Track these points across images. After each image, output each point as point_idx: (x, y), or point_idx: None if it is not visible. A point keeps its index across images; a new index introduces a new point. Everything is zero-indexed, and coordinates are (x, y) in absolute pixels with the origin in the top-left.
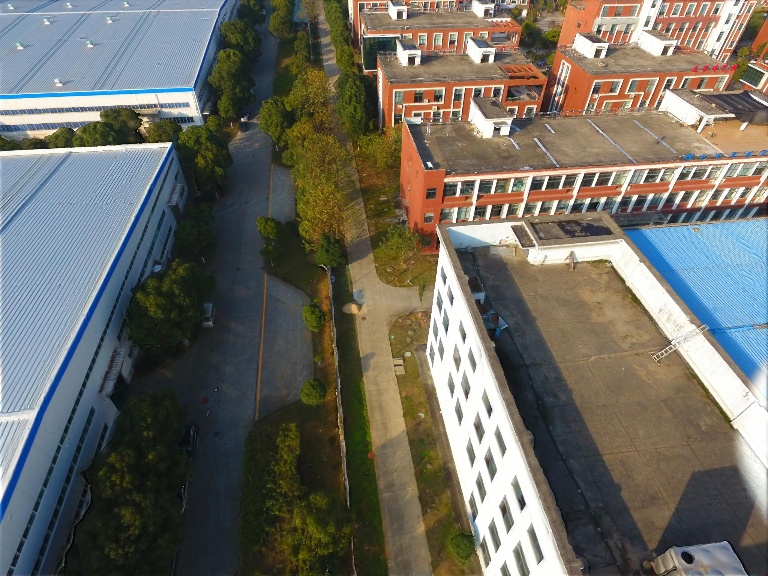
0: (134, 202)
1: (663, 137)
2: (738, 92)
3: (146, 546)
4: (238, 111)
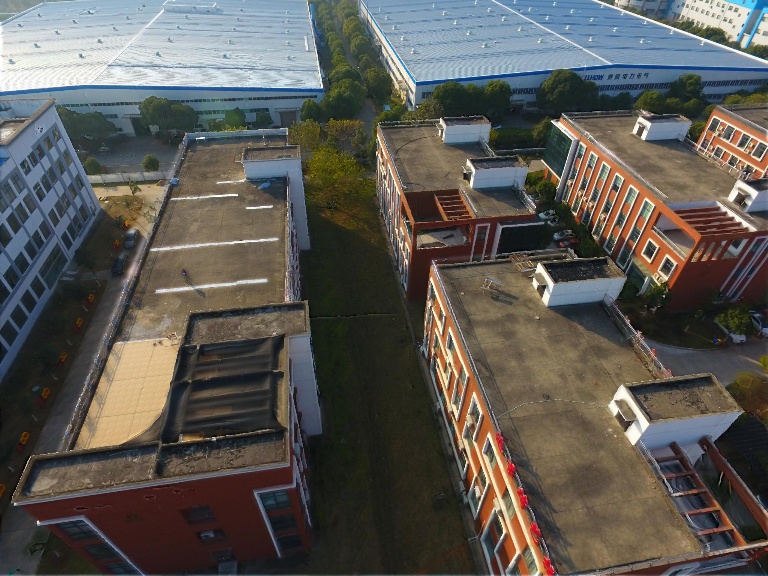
0: None
1: (202, 293)
2: (284, 416)
3: None
4: None
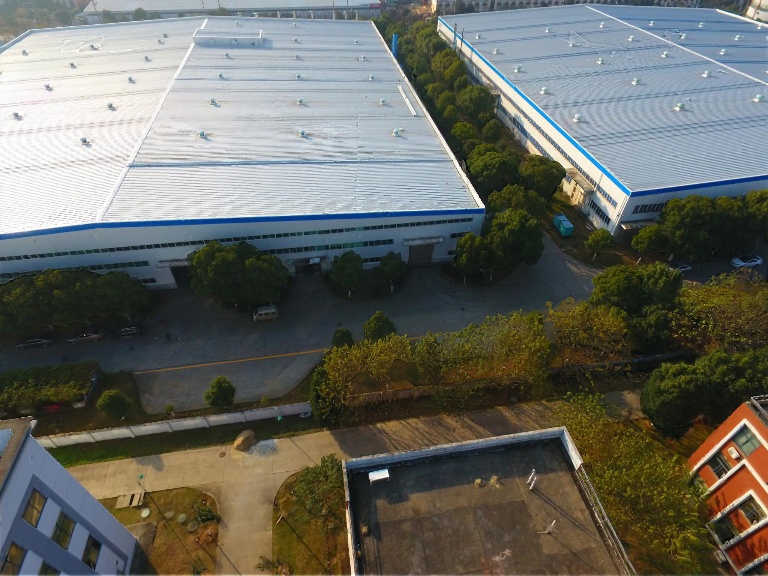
0: (358, 210)
1: None
2: None
3: (2, 310)
4: (678, 257)
